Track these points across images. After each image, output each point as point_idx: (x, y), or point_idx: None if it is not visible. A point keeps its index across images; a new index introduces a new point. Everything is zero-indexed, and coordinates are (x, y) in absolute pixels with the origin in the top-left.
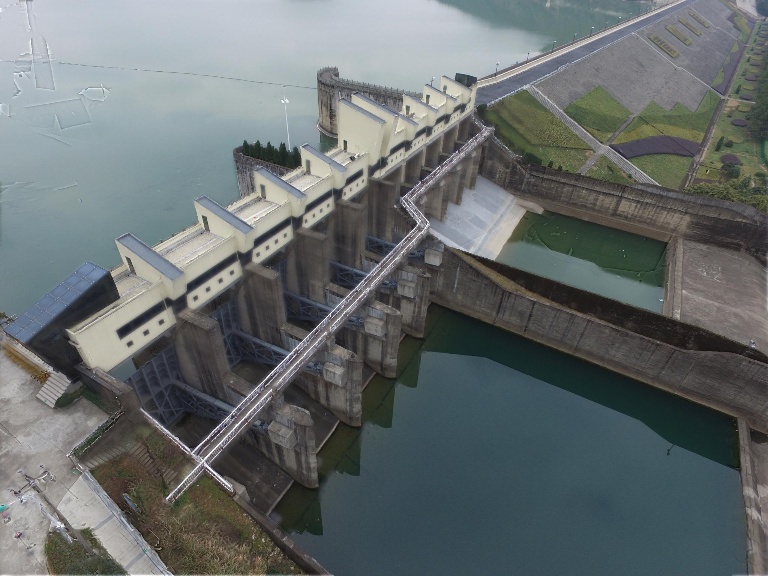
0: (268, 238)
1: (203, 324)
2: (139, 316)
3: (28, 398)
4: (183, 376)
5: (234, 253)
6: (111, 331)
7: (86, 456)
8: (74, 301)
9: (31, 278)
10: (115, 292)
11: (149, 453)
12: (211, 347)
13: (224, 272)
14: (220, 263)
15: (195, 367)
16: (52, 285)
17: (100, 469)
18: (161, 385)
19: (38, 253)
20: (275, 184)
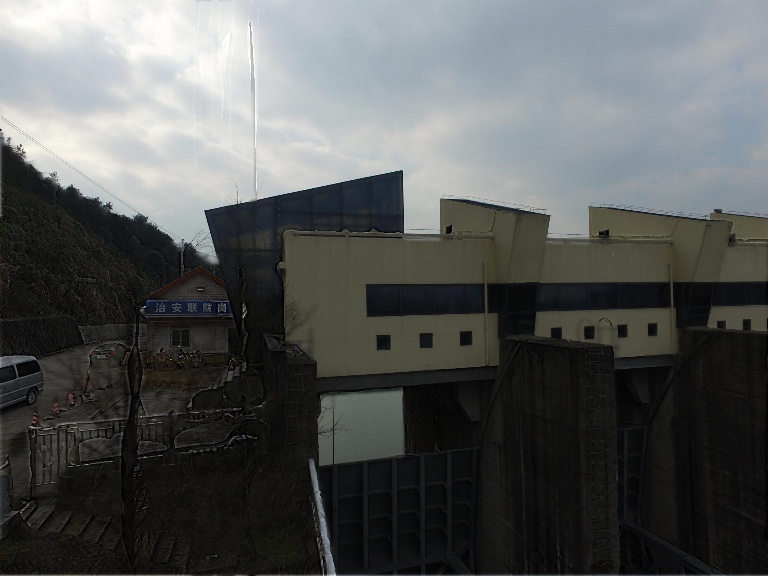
0: (749, 303)
1: (565, 343)
2: (424, 288)
3: (185, 397)
4: (478, 567)
5: (664, 286)
6: (357, 280)
7: (84, 489)
8: (322, 193)
9: (360, 430)
10: (399, 225)
11: (125, 485)
12: (575, 421)
13: (634, 315)
14: (628, 288)
15: (512, 527)
16: (374, 439)
17: (45, 540)
18: (422, 549)
19: (381, 416)
20: (766, 218)
